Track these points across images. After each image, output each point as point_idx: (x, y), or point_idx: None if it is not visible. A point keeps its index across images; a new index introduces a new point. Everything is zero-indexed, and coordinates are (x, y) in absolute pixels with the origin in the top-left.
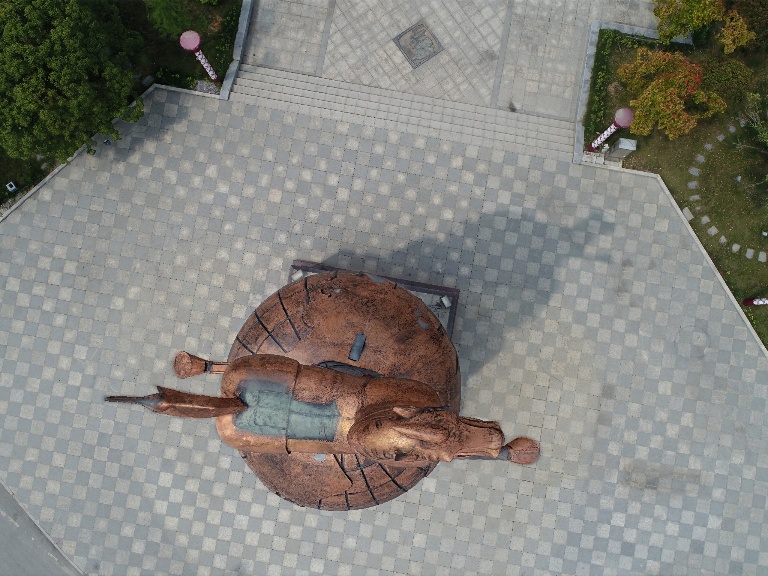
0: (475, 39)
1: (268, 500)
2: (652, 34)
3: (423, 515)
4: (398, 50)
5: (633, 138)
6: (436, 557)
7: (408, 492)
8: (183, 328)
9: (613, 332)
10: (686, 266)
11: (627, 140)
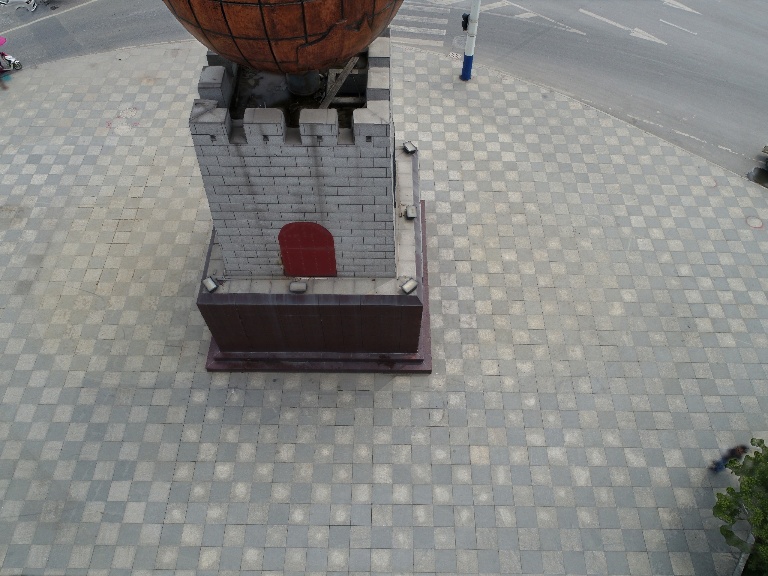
0: None
1: None
2: None
3: None
4: None
5: None
6: None
7: None
8: (543, 281)
9: (2, 352)
10: None
11: None
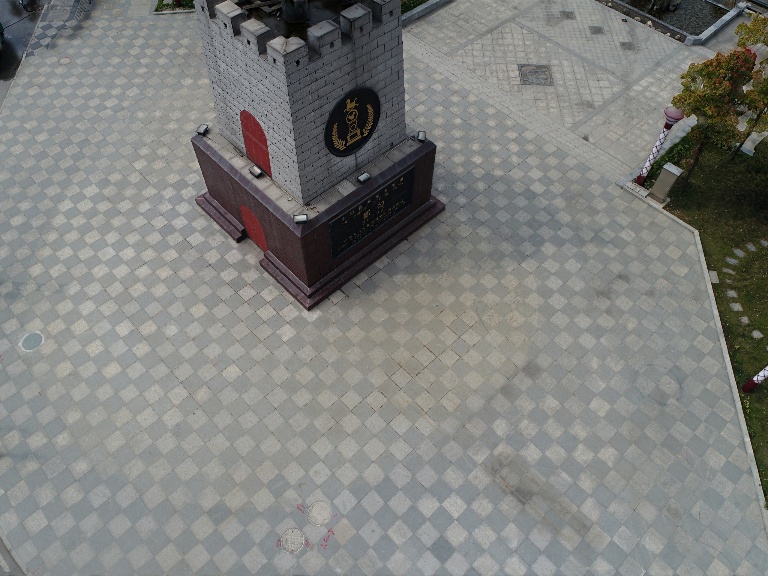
0: (583, 92)
1: (144, 252)
2: (746, 150)
3: (256, 353)
4: (517, 71)
5: (687, 199)
6: (232, 399)
7: (262, 325)
8: (212, 116)
9: (572, 322)
10: (688, 314)
11: (675, 166)
